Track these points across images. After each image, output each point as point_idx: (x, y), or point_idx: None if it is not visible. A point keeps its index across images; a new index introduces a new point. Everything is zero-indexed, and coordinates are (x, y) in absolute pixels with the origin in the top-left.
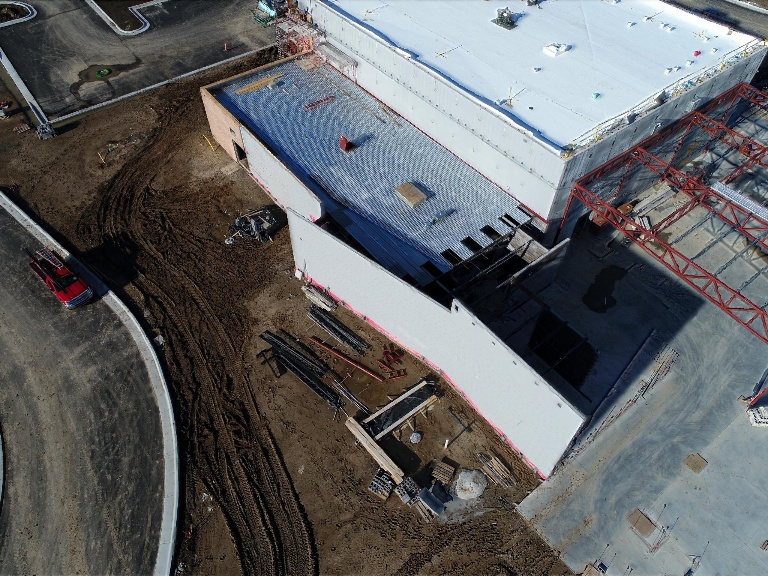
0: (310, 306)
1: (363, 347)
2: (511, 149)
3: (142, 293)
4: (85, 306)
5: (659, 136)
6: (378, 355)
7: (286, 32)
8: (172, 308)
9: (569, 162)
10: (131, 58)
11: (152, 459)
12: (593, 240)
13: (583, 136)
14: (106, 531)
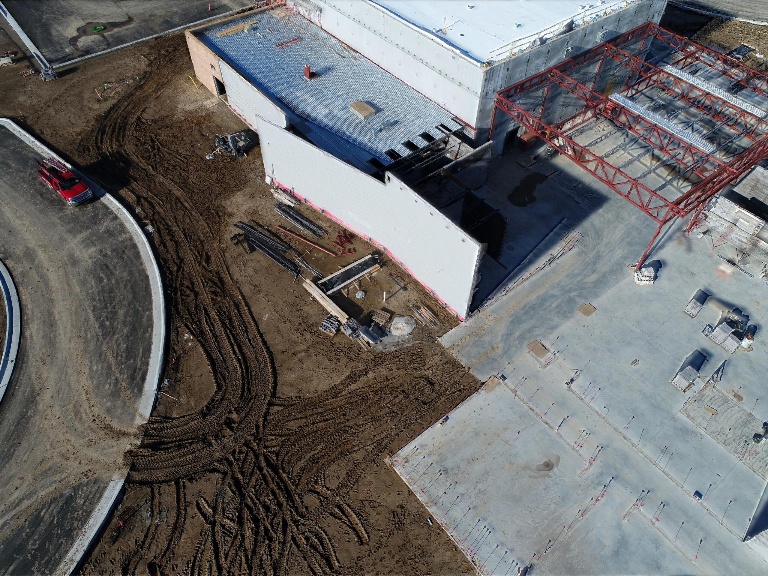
0: (277, 203)
1: (320, 232)
2: (444, 67)
3: (134, 195)
4: (86, 205)
5: (573, 62)
6: (333, 238)
7: None
8: (160, 206)
9: (487, 72)
10: (124, 17)
11: (143, 311)
12: (521, 154)
13: (502, 55)
14: (106, 359)
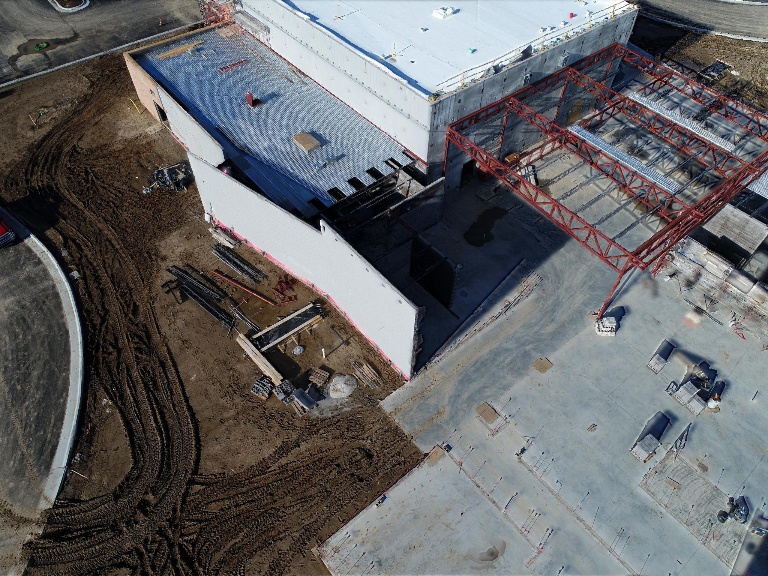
0: (216, 244)
1: (260, 278)
2: (392, 98)
3: (62, 236)
4: (8, 248)
5: (534, 89)
6: (273, 284)
7: (206, 2)
8: (89, 248)
9: (436, 105)
10: (69, 33)
11: (59, 372)
12: (481, 186)
13: (454, 84)
14: (13, 430)
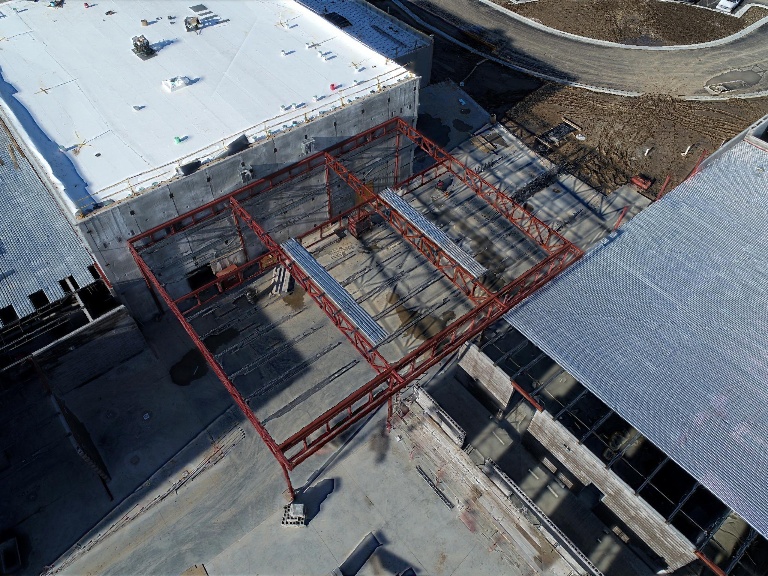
0: None
1: None
2: None
3: None
4: None
5: (270, 182)
6: None
7: None
8: None
9: (87, 223)
10: None
11: None
12: (220, 296)
13: None
14: None
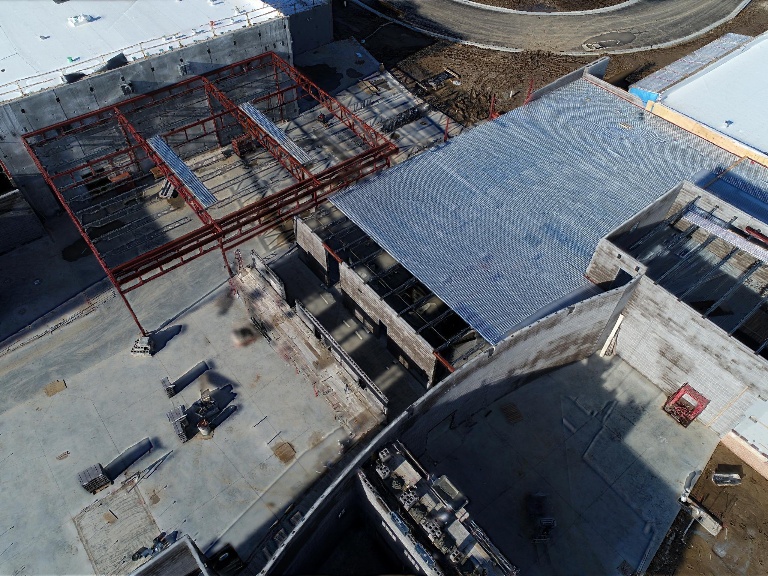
0: None
1: None
2: None
3: None
4: None
5: (151, 98)
6: None
7: None
8: None
9: None
10: None
11: None
12: None
13: None
14: None
